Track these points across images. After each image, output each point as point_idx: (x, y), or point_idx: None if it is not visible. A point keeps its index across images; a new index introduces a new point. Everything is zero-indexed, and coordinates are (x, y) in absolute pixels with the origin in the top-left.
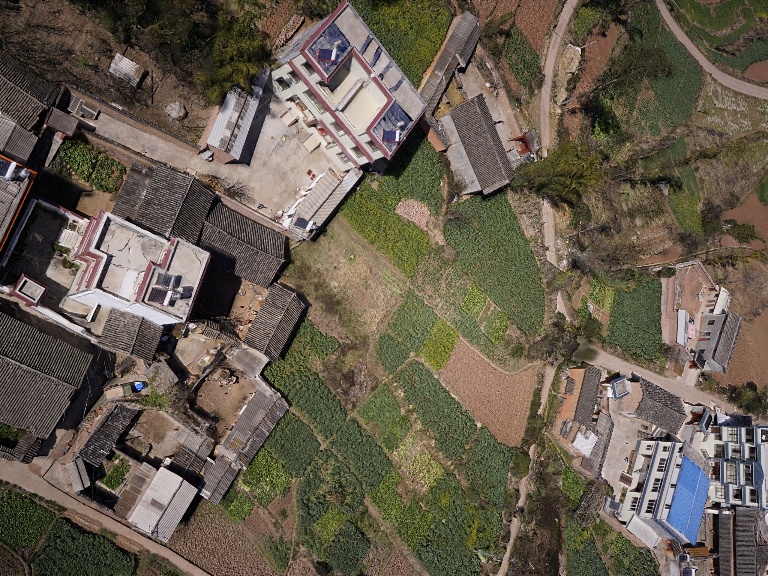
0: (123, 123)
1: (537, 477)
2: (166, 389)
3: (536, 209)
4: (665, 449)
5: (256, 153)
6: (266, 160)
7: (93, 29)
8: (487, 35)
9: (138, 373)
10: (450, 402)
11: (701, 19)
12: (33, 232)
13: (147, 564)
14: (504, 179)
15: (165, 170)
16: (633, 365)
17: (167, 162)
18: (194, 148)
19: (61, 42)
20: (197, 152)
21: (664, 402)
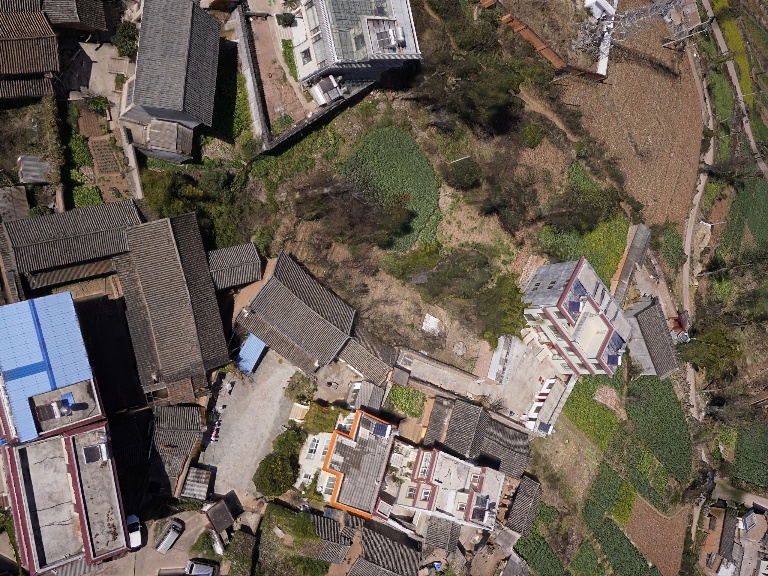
0: (427, 364)
1: None
2: (460, 570)
3: None
4: None
5: None
6: (514, 375)
7: (410, 296)
8: (651, 235)
9: (436, 556)
10: (631, 549)
11: None
12: None
13: None
14: (675, 367)
15: (462, 403)
16: (754, 495)
17: (454, 390)
18: (474, 378)
19: (392, 311)
20: (474, 379)
21: None
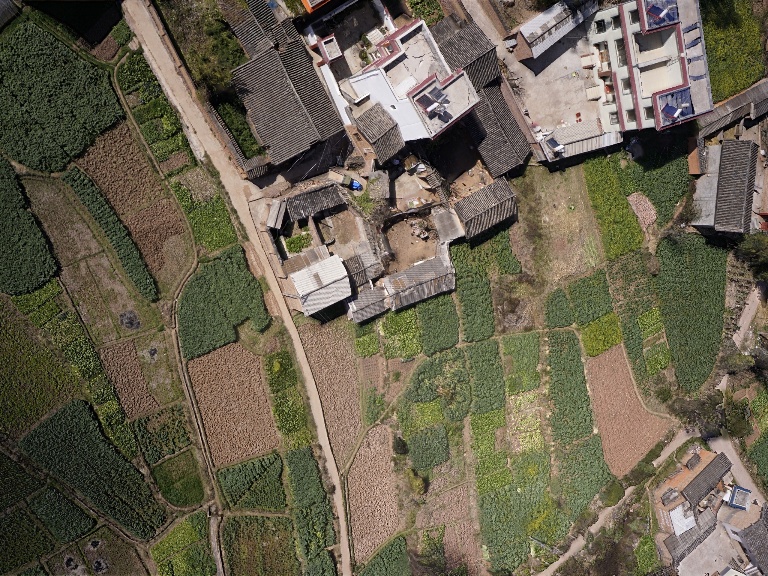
0: None
1: (619, 520)
2: (377, 197)
3: (746, 288)
4: None
5: (547, 70)
6: (551, 81)
7: None
8: None
9: (361, 175)
10: (583, 390)
11: None
12: (354, 16)
13: (275, 332)
14: (740, 227)
15: (477, 28)
16: (760, 494)
17: None
18: (505, 31)
19: None
20: (504, 37)
21: None
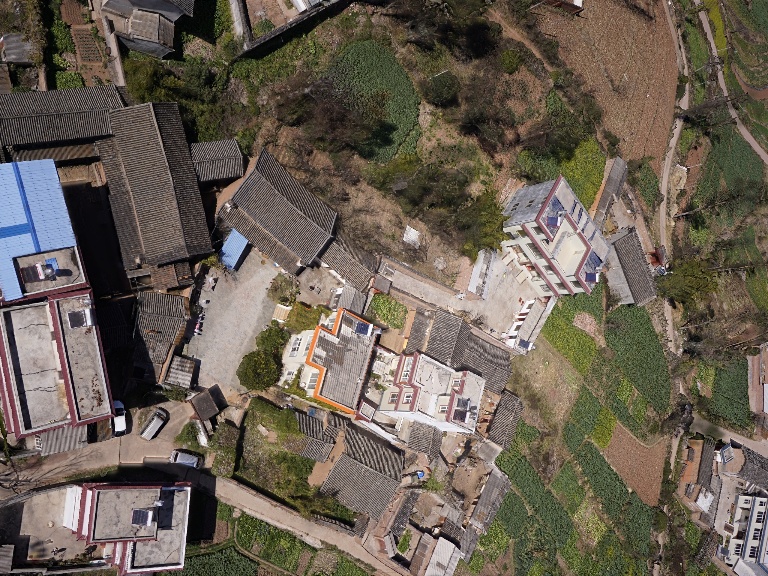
0: (408, 276)
1: (668, 530)
2: (442, 478)
3: (661, 309)
4: (761, 504)
5: None
6: (494, 294)
7: (391, 208)
8: (628, 171)
9: (419, 465)
10: (611, 473)
11: (758, 115)
12: None
13: None
14: (653, 295)
15: (443, 313)
16: (731, 432)
17: (435, 303)
18: (454, 292)
19: (373, 221)
20: (454, 294)
21: (760, 465)
